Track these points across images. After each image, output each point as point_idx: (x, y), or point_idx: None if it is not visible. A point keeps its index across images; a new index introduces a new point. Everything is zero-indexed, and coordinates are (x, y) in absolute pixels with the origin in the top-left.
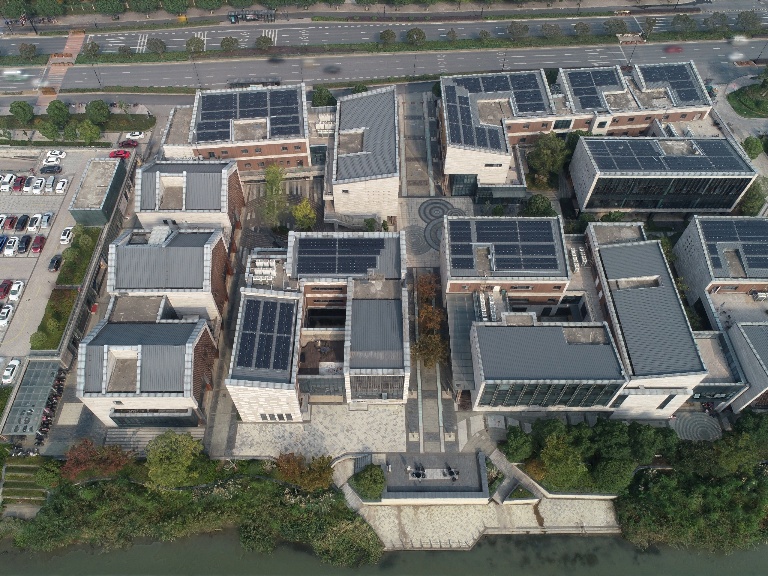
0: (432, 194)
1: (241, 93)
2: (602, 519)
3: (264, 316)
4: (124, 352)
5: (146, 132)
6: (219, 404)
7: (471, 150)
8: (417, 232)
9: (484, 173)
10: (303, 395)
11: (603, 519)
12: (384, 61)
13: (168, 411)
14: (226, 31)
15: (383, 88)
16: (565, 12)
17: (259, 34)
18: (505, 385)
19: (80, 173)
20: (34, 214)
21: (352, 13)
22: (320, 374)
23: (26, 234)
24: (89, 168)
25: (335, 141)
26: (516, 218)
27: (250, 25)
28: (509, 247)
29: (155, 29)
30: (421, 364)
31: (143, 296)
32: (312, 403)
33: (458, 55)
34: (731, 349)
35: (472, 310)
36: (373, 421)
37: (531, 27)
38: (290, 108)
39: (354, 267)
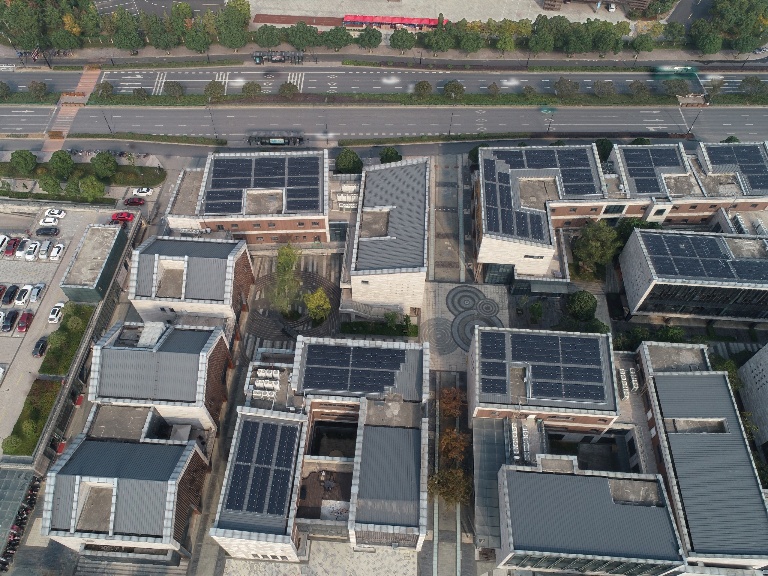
0: (462, 279)
1: (257, 158)
2: None
3: (262, 443)
4: (99, 482)
5: (155, 188)
6: (207, 532)
7: (510, 241)
8: (443, 326)
9: (523, 264)
10: (301, 534)
11: None
12: (417, 115)
13: (145, 550)
14: (249, 73)
15: (414, 159)
16: (619, 65)
17: (284, 78)
18: (537, 555)
19: (78, 237)
20: (24, 284)
21: (386, 57)
22: (322, 516)
23: (13, 308)
24: (87, 235)
25: (357, 221)
26: (558, 333)
27: (276, 67)
28: (549, 369)
29: (175, 67)
30: (439, 496)
31: (128, 406)
32: (312, 538)
33: (499, 112)
34: None
35: (502, 441)
36: (380, 567)
37: (581, 81)
38: (310, 178)
39: (369, 384)
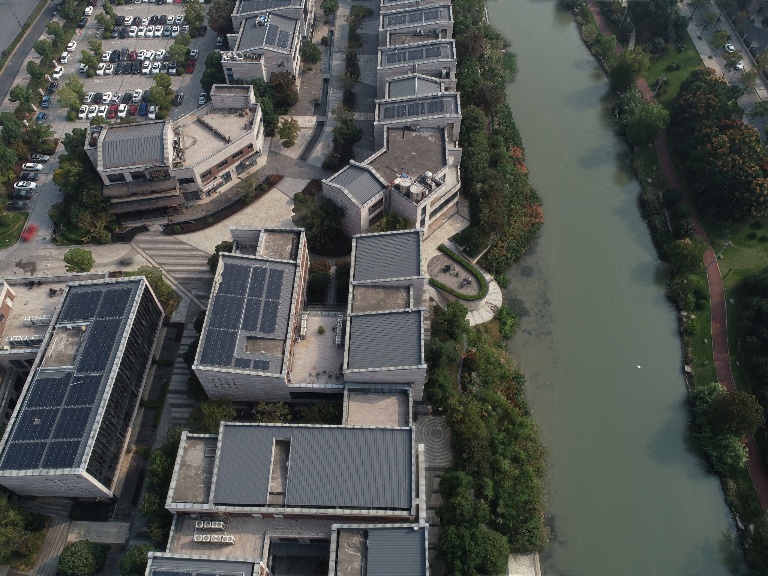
0: None
1: None
2: (528, 571)
3: None
4: None
5: None
6: None
7: None
8: None
9: None
10: None
11: (528, 570)
12: None
13: None
14: None
15: None
16: None
17: None
18: None
19: None
20: None
21: None
22: None
23: None
24: None
25: None
26: None
27: None
28: None
29: None
30: None
31: None
32: None
33: None
34: (368, 386)
35: None
36: None
37: None
38: None
39: None
